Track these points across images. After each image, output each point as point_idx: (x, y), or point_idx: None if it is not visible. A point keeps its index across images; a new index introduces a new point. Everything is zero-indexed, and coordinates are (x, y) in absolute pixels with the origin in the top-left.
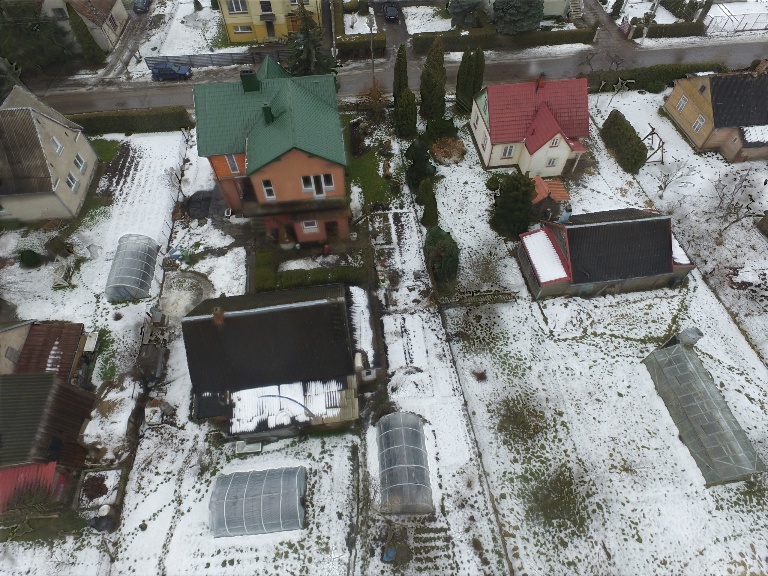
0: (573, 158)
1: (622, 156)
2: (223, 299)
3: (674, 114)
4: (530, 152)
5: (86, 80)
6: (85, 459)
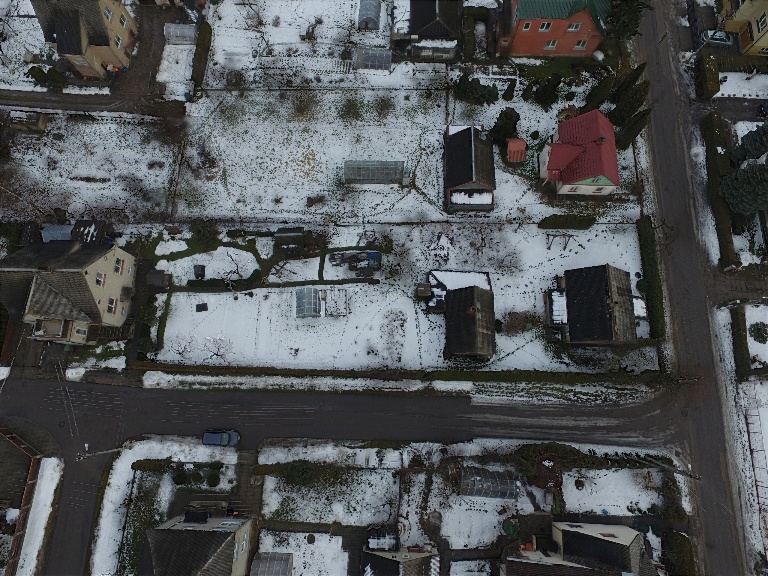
0: None
1: None
2: None
3: None
4: None
5: None
6: None
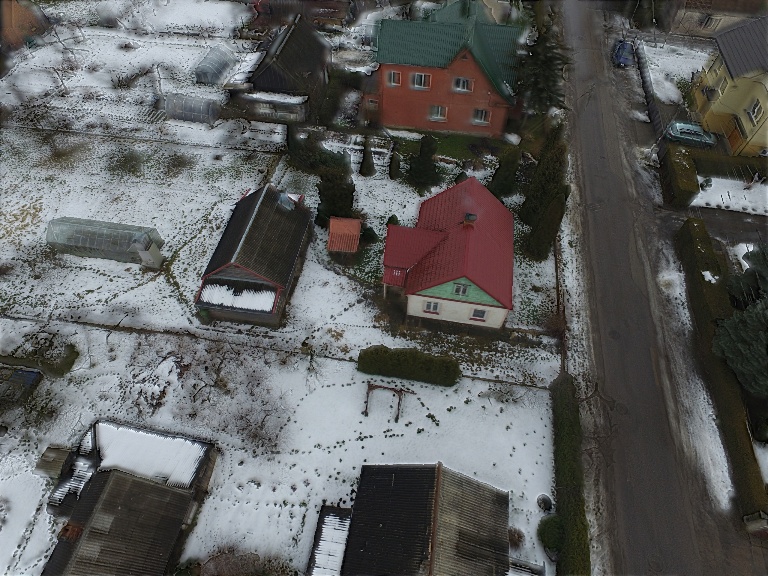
0: None
1: None
2: (325, 48)
3: None
4: None
5: (620, 24)
6: (276, 29)
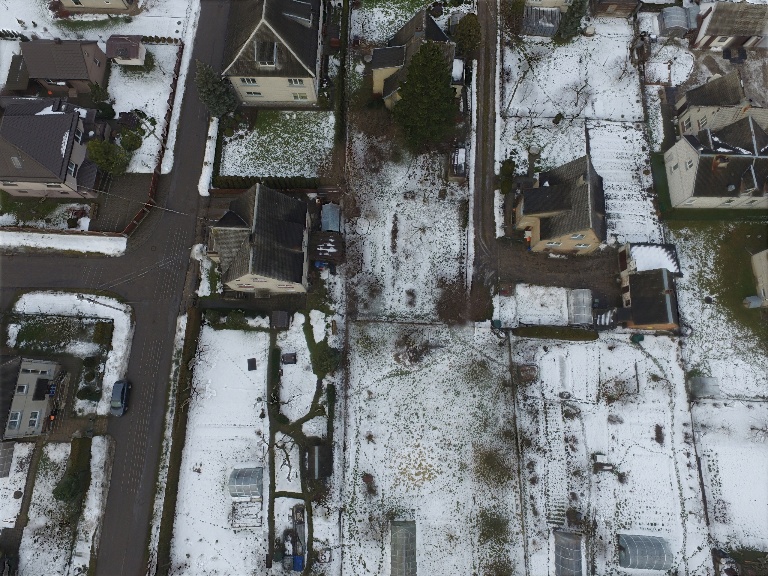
0: None
1: None
2: None
3: None
4: None
5: None
6: None
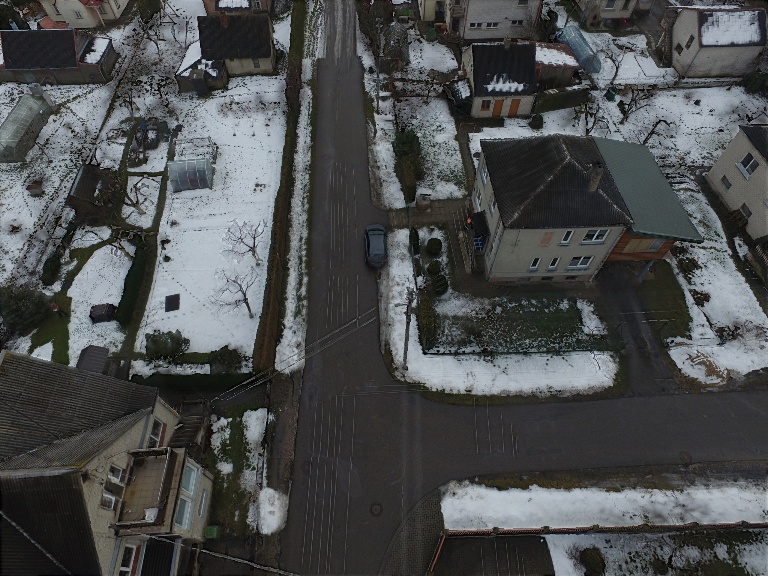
0: (115, 19)
1: None
2: None
3: None
4: (54, 4)
5: None
6: None
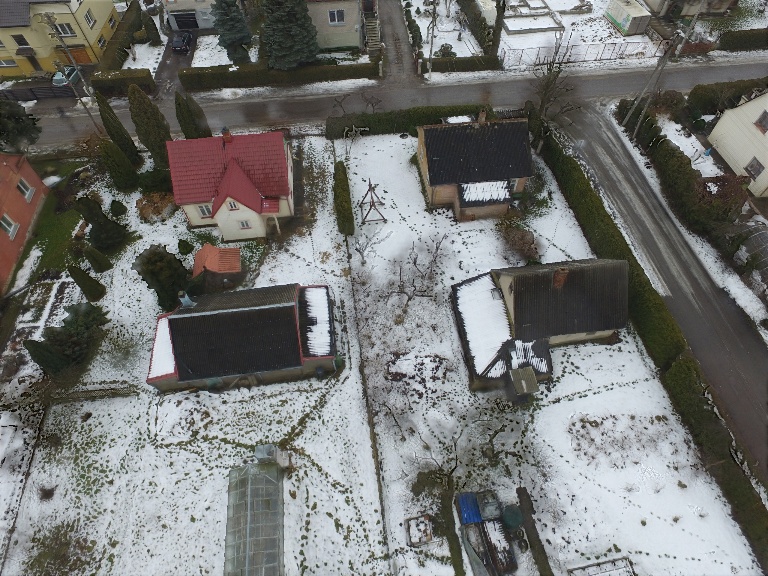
0: (289, 216)
1: (337, 214)
2: None
3: (420, 163)
4: None
5: None
6: None
